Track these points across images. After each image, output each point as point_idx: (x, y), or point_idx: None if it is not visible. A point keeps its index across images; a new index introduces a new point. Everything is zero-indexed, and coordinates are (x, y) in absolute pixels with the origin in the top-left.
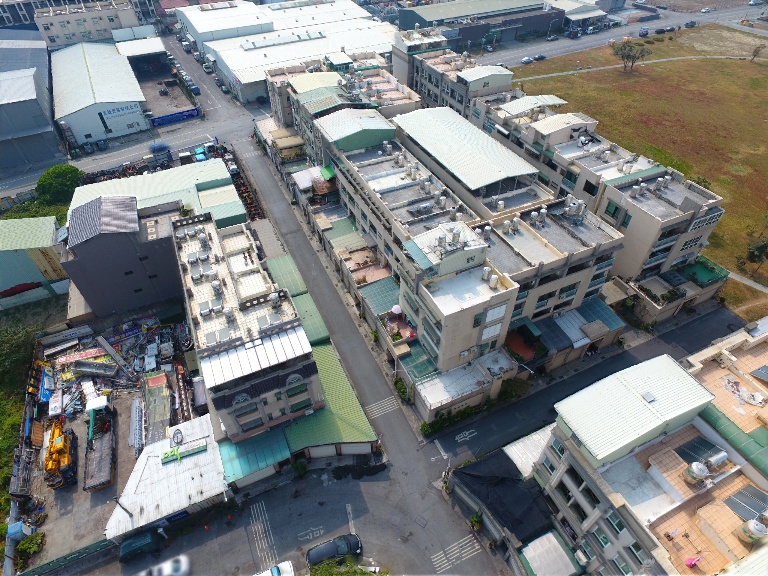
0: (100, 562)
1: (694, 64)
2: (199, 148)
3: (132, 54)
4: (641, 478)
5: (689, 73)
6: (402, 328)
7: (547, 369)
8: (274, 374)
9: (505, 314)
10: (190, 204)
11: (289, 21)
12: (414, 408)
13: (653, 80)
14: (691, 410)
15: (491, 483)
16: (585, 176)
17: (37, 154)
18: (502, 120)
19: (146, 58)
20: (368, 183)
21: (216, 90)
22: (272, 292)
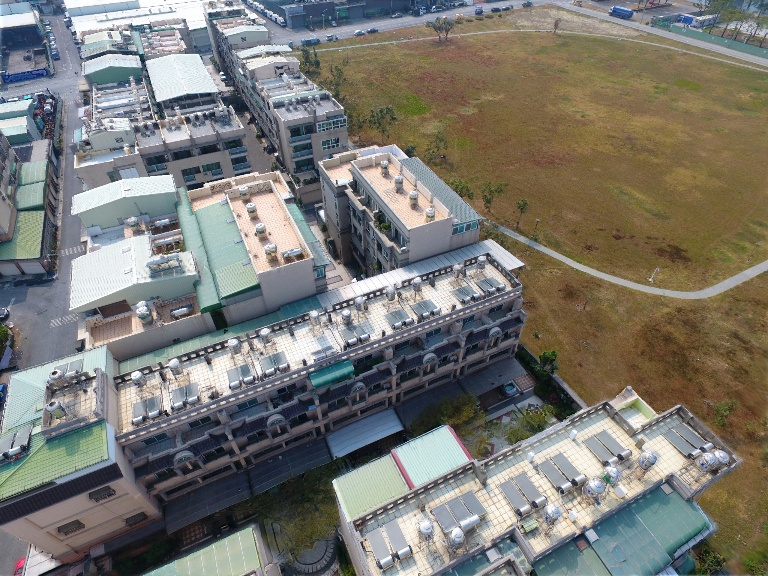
0: None
1: (504, 36)
2: None
3: (4, 26)
4: (120, 236)
5: (494, 43)
6: None
7: None
8: None
9: None
10: None
11: (158, 0)
12: None
13: (458, 48)
14: (153, 196)
15: None
16: (265, 98)
17: None
18: (240, 64)
19: (22, 31)
20: (101, 103)
21: (75, 56)
22: None
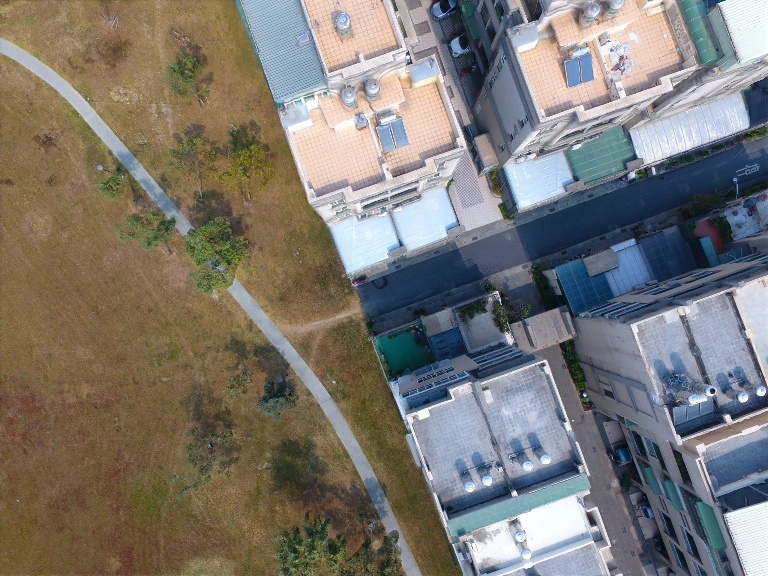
0: None
1: None
2: None
3: None
4: None
5: None
6: None
7: None
8: None
9: None
10: None
11: None
12: None
13: None
14: None
15: None
16: None
17: None
18: None
19: None
20: None
21: None
22: None
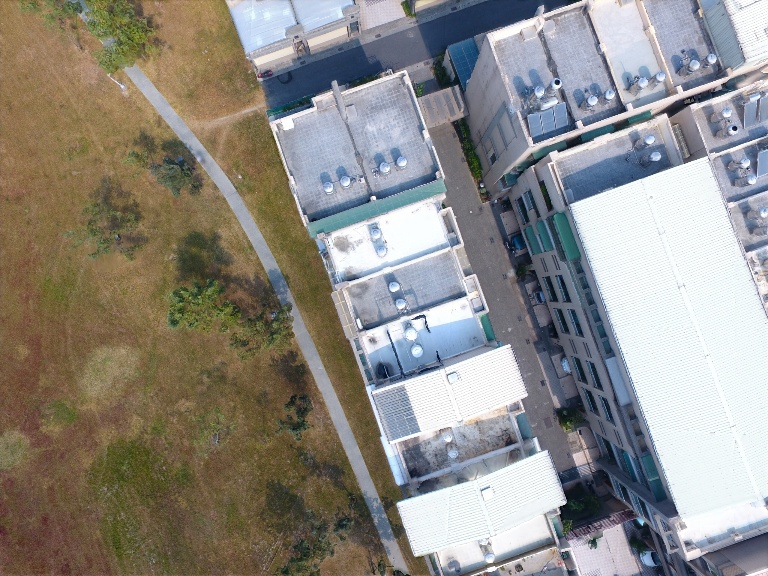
0: None
1: None
2: None
3: None
4: None
5: None
6: None
7: None
8: None
9: None
10: None
11: None
12: None
13: None
14: None
15: None
16: None
17: None
18: None
19: None
20: None
21: None
22: None
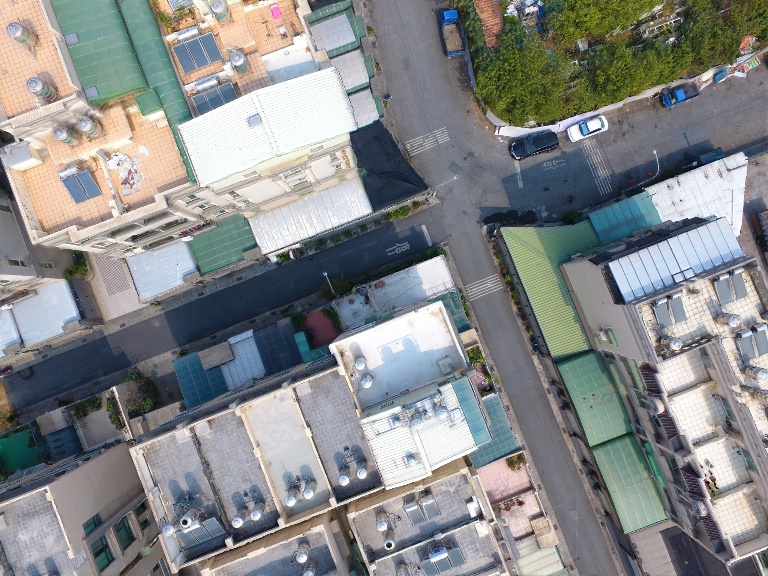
0: (734, 153)
1: None
2: None
3: None
4: None
5: None
6: None
7: None
8: None
9: None
10: None
11: None
12: None
13: None
14: None
15: (394, 174)
16: None
17: None
18: None
19: None
20: None
21: None
22: None
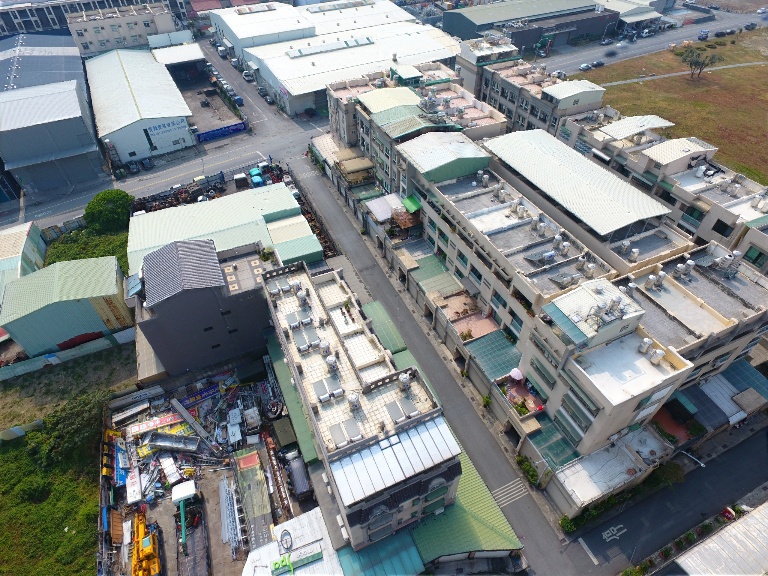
0: None
1: (764, 71)
2: (254, 169)
3: (170, 62)
4: None
5: (761, 81)
6: (523, 396)
7: (694, 446)
8: (416, 480)
9: (667, 394)
10: (260, 239)
11: (330, 25)
12: (546, 495)
13: (725, 89)
14: None
15: None
16: (717, 214)
17: (80, 175)
18: (601, 144)
19: (183, 65)
20: None
21: (260, 100)
22: (399, 371)
